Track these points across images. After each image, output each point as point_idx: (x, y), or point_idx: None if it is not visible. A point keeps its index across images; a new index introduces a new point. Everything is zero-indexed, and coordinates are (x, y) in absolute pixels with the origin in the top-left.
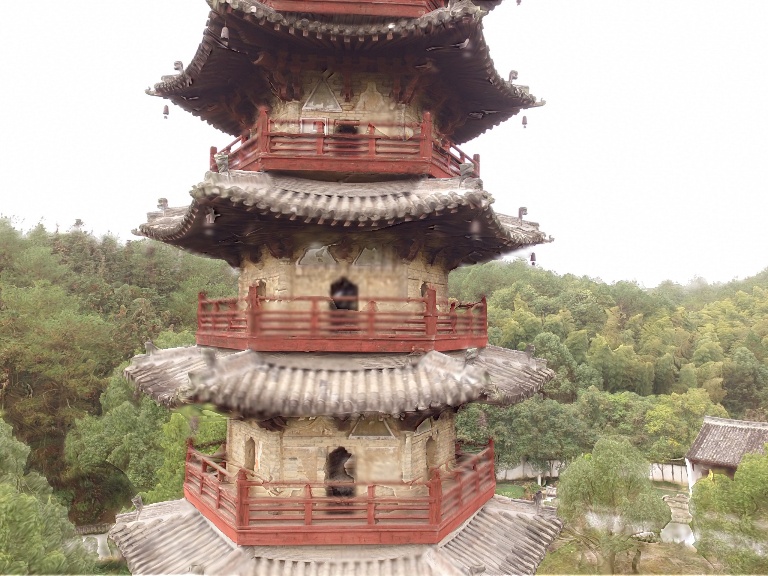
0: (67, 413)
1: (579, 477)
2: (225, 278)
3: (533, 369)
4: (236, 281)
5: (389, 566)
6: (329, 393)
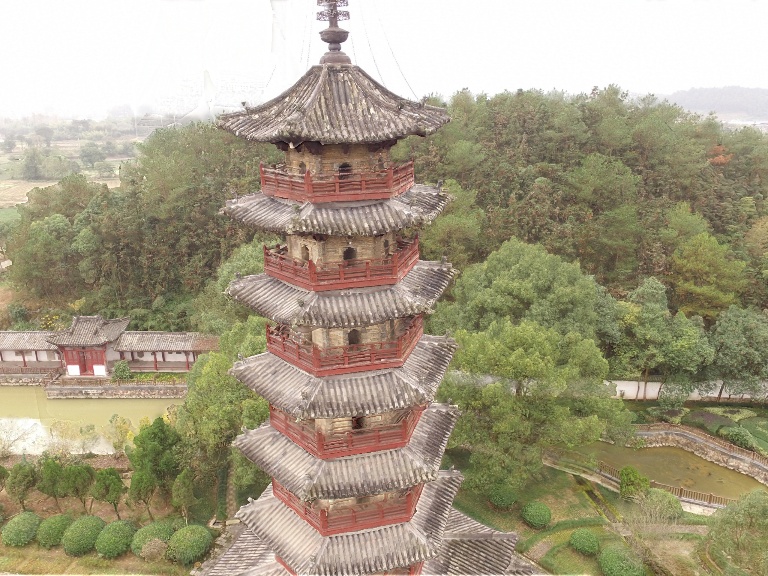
0: (449, 287)
1: (741, 507)
2: (643, 143)
3: (425, 470)
4: (653, 147)
5: (313, 532)
6: (279, 461)
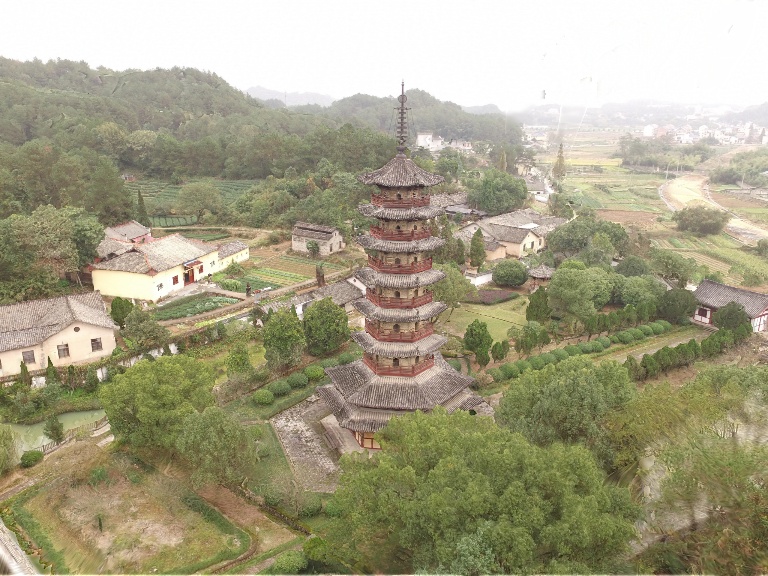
0: None
1: None
2: None
3: None
4: None
5: None
6: None
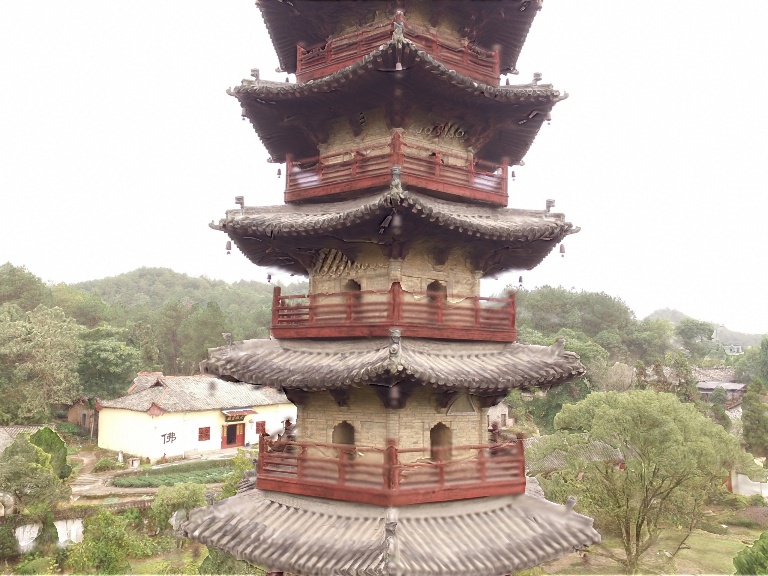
0: None
1: None
2: None
3: None
4: None
5: None
6: None
